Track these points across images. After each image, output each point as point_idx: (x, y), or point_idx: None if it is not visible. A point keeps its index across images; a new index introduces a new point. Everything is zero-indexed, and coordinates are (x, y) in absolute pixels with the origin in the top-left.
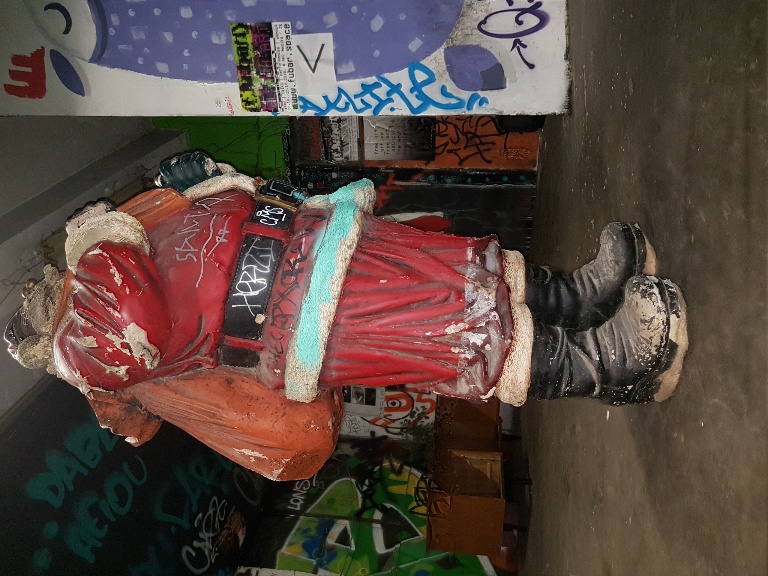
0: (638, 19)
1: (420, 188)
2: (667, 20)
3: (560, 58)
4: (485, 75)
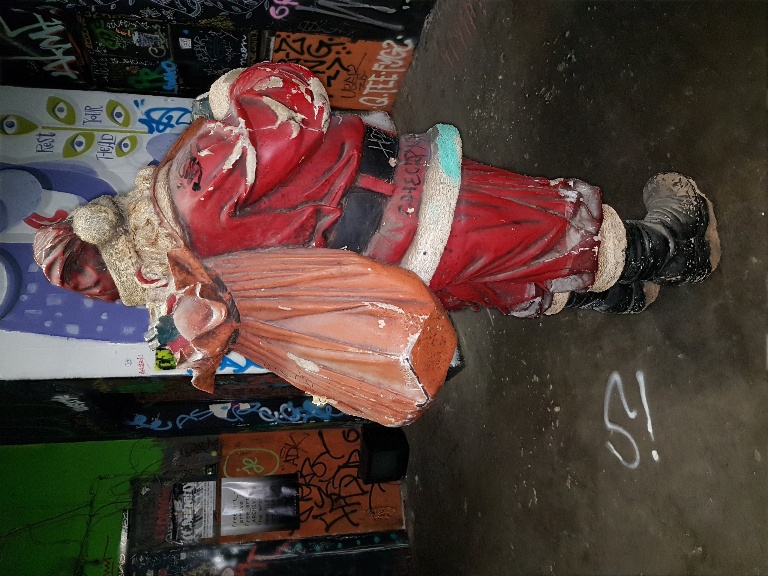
0: (545, 154)
1: (286, 562)
2: (577, 111)
3: None
4: None
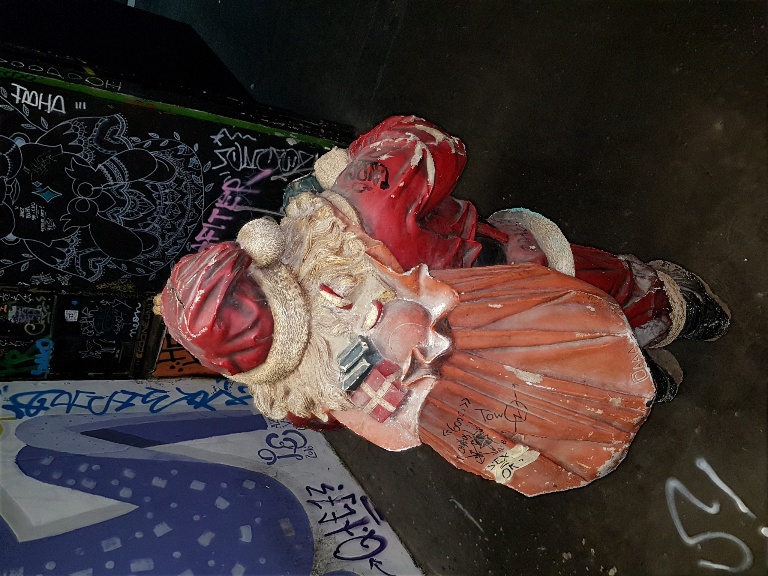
0: None
1: None
2: None
3: (412, 567)
4: None
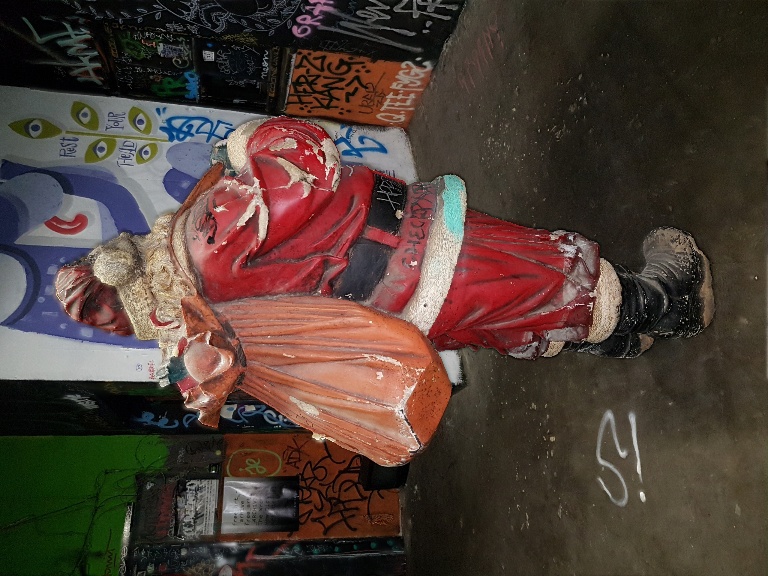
0: (554, 190)
1: (283, 562)
2: (586, 153)
3: None
4: None
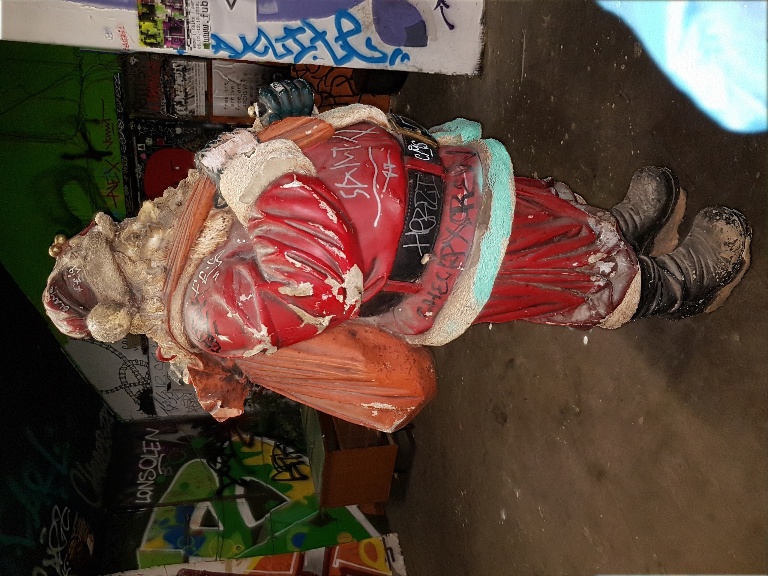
0: None
1: None
2: None
3: (476, 22)
4: (409, 31)
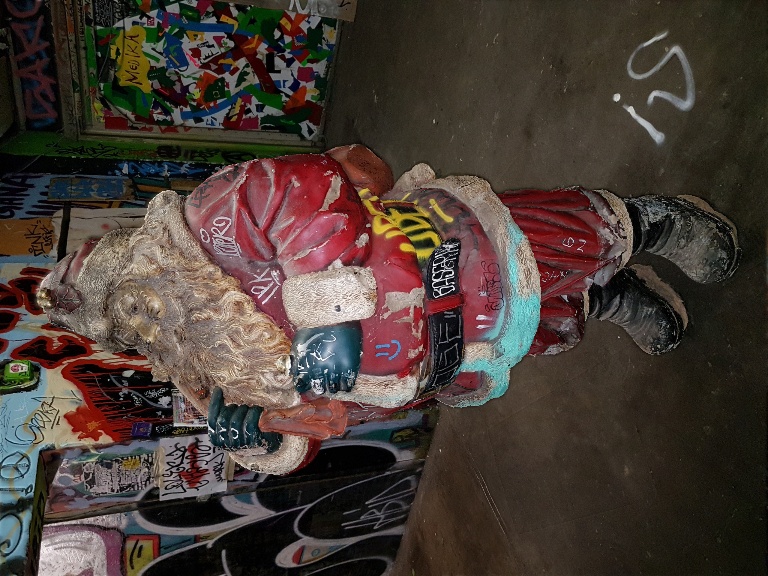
0: None
1: None
2: None
3: None
4: None
